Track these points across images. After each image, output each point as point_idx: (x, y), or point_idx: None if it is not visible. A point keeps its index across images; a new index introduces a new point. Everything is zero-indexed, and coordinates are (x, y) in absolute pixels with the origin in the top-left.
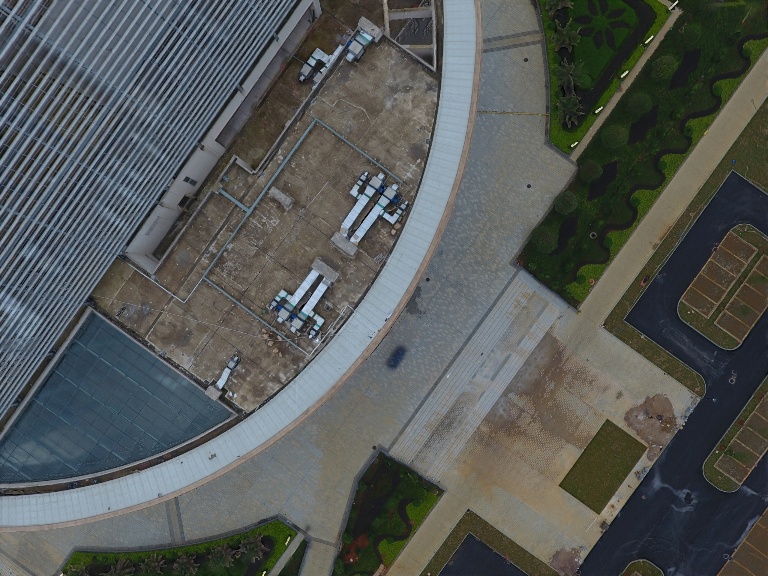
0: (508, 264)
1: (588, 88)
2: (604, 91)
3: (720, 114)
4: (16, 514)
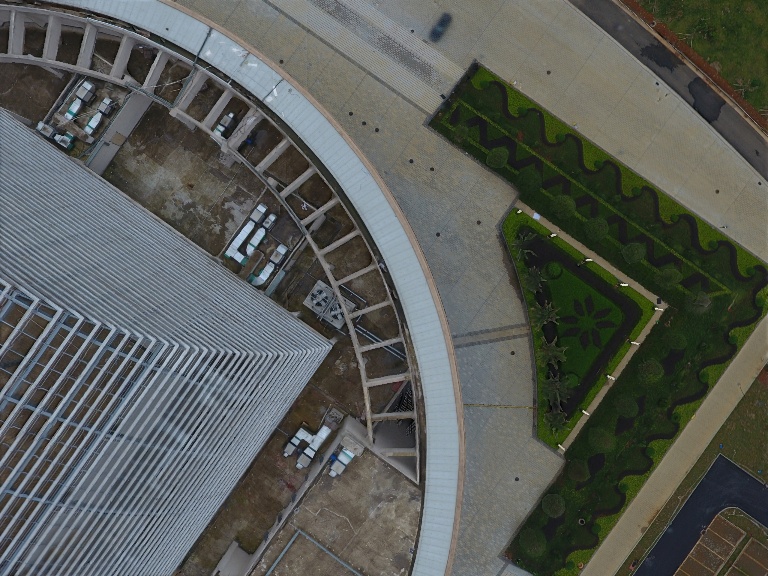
0: (497, 557)
1: (575, 386)
2: (591, 387)
3: (707, 398)
4: None
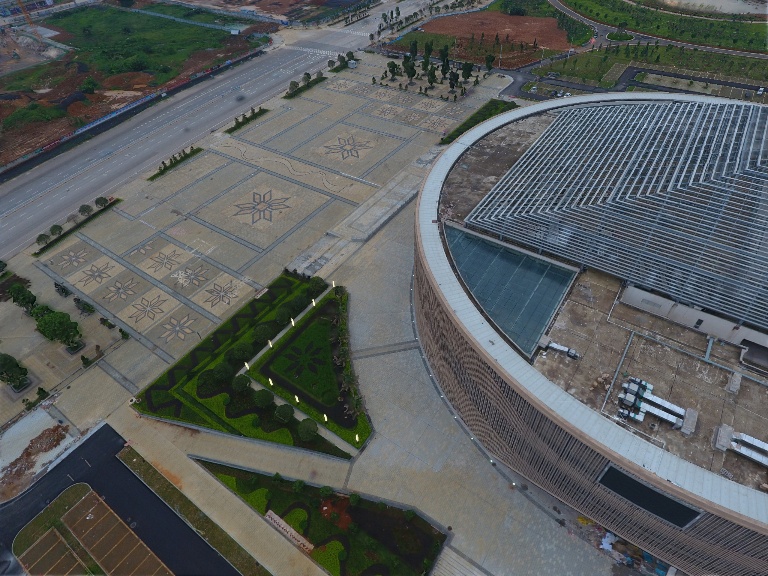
0: None
1: None
2: None
3: None
4: (430, 242)
